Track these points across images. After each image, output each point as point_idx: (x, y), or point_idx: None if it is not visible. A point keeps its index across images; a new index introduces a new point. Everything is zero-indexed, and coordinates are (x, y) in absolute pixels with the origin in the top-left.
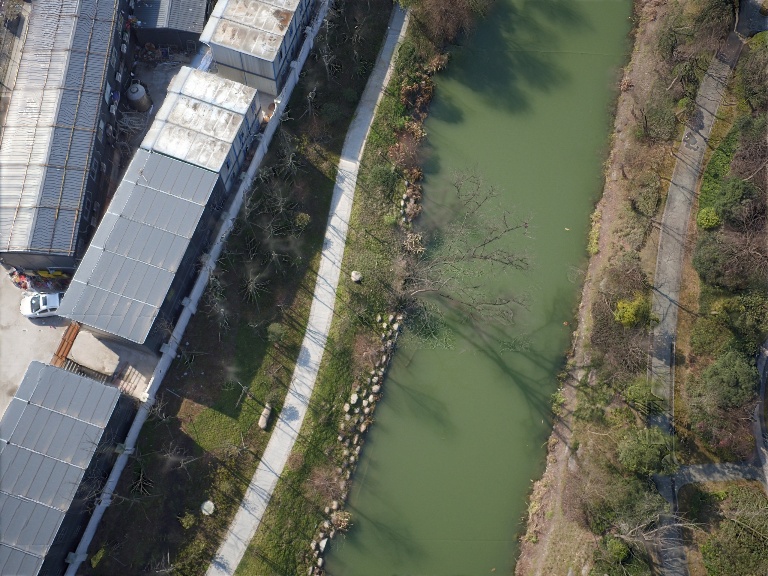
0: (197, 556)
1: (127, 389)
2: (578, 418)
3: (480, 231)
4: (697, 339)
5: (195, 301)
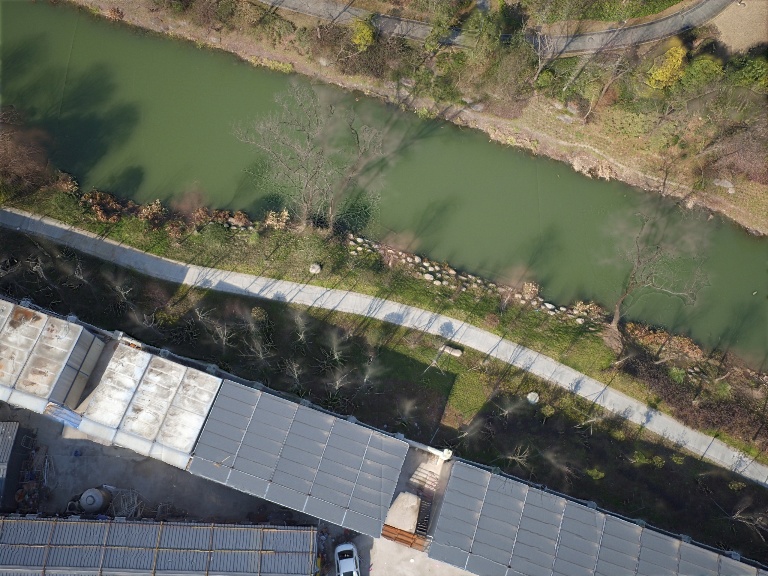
0: (573, 404)
1: (433, 480)
2: (441, 98)
3: (265, 161)
4: None
5: None
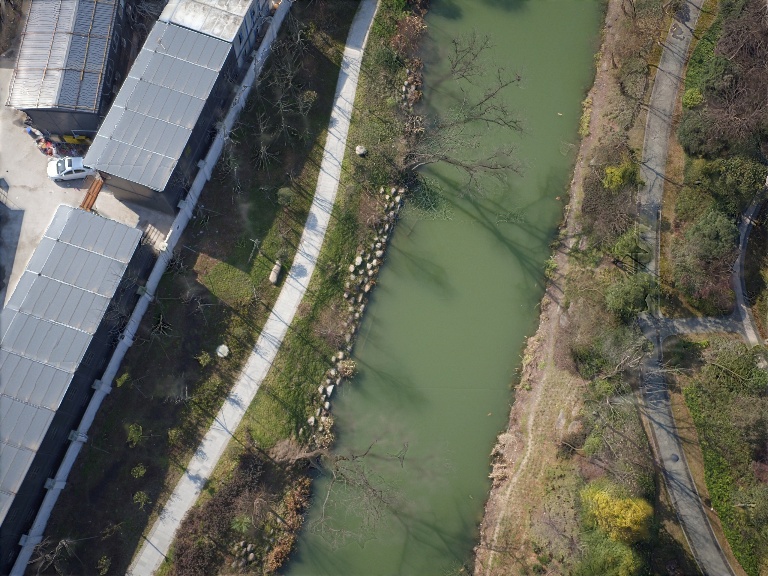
0: (213, 392)
1: None
2: (569, 280)
3: (477, 115)
4: (681, 206)
5: (210, 168)
